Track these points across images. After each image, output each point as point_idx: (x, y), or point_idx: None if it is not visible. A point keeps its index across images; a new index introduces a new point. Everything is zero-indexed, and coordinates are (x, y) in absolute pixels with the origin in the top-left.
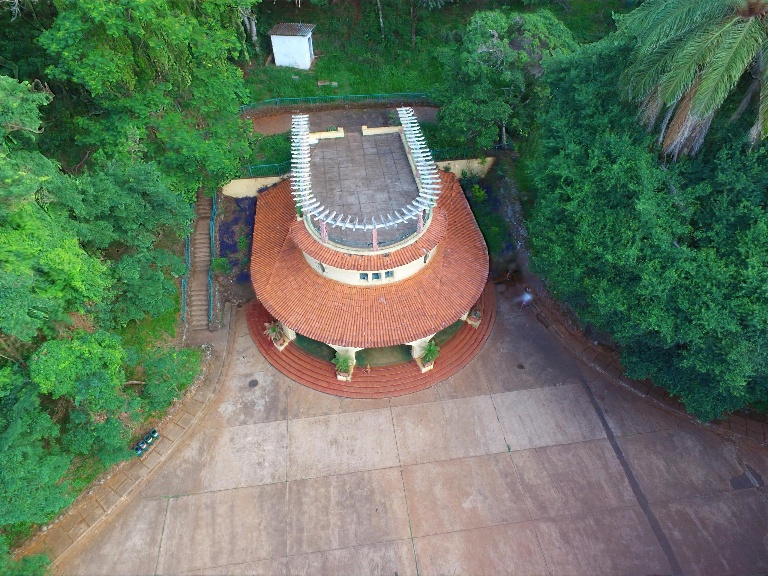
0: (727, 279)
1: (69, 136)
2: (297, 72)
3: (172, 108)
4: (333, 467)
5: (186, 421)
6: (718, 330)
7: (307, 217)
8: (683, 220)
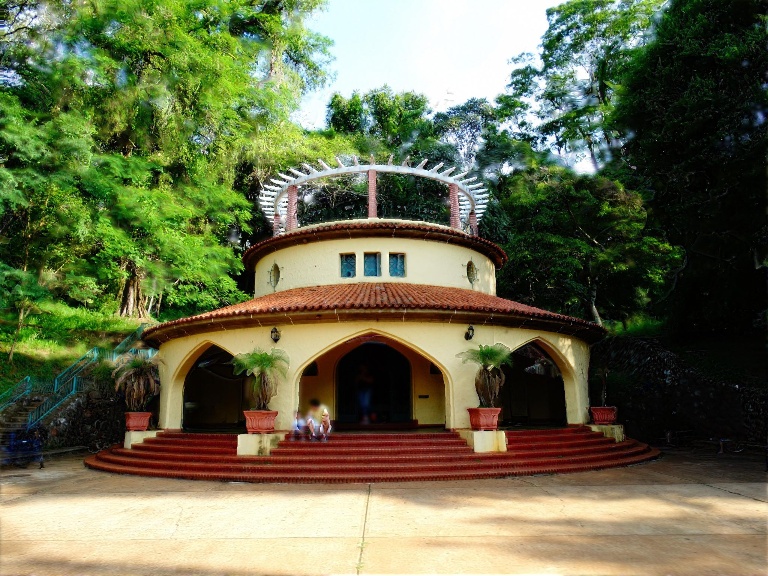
0: None
1: None
2: None
3: None
4: (78, 530)
5: None
6: None
7: None
8: None
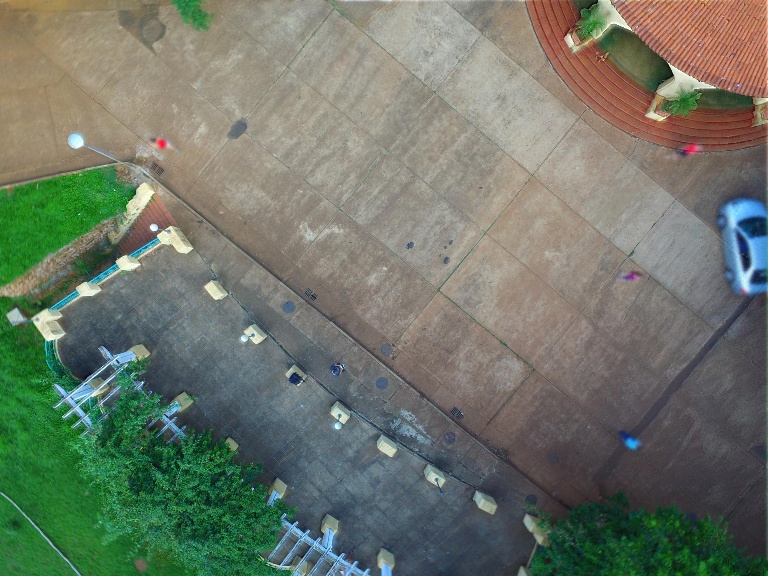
0: None
1: None
2: None
3: None
4: (481, 119)
5: None
6: None
7: None
8: None
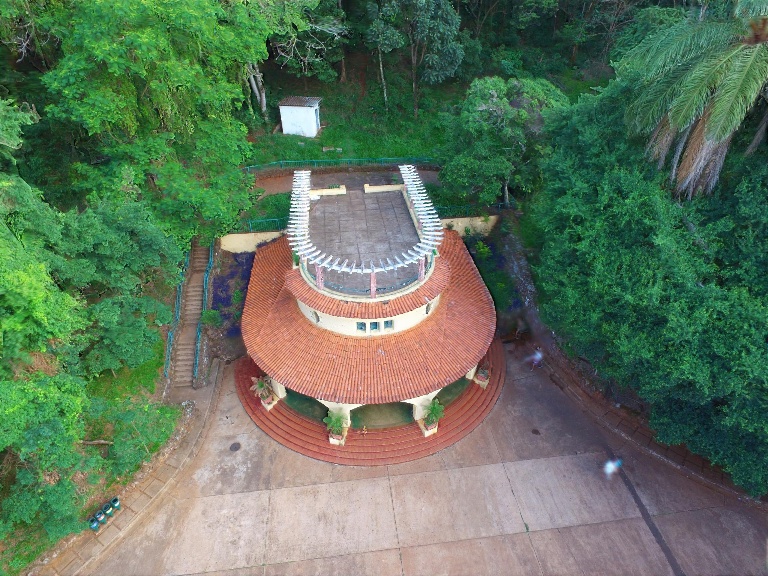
0: (767, 318)
1: None
2: (303, 139)
3: (174, 158)
4: (320, 548)
5: (154, 489)
6: (764, 378)
7: (303, 265)
8: (706, 259)
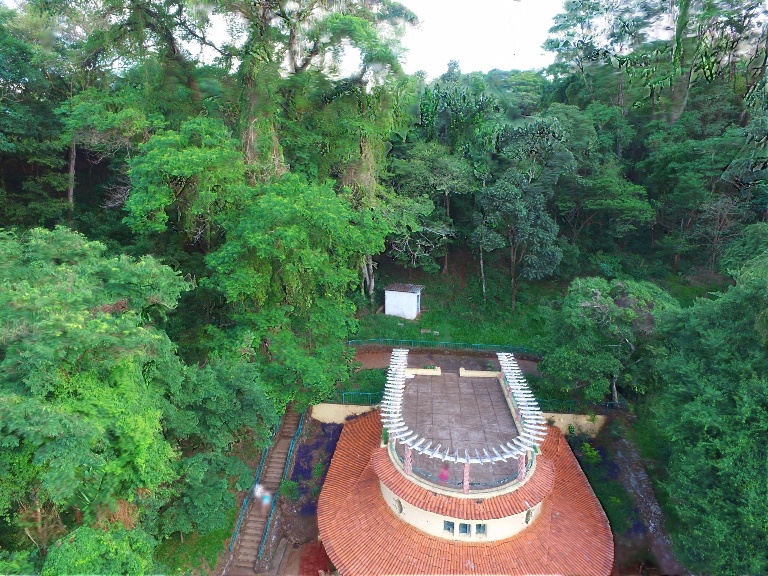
0: None
1: (196, 347)
2: (403, 320)
3: (288, 328)
4: None
5: None
6: None
7: (392, 444)
8: None
